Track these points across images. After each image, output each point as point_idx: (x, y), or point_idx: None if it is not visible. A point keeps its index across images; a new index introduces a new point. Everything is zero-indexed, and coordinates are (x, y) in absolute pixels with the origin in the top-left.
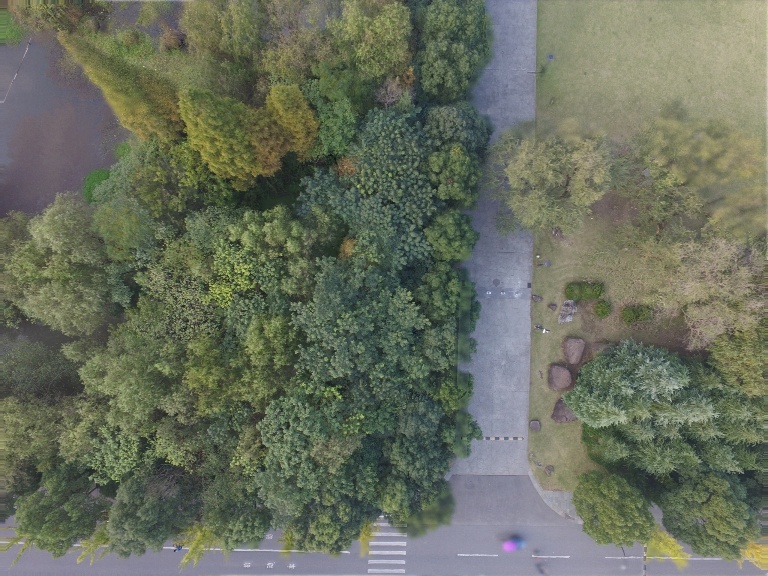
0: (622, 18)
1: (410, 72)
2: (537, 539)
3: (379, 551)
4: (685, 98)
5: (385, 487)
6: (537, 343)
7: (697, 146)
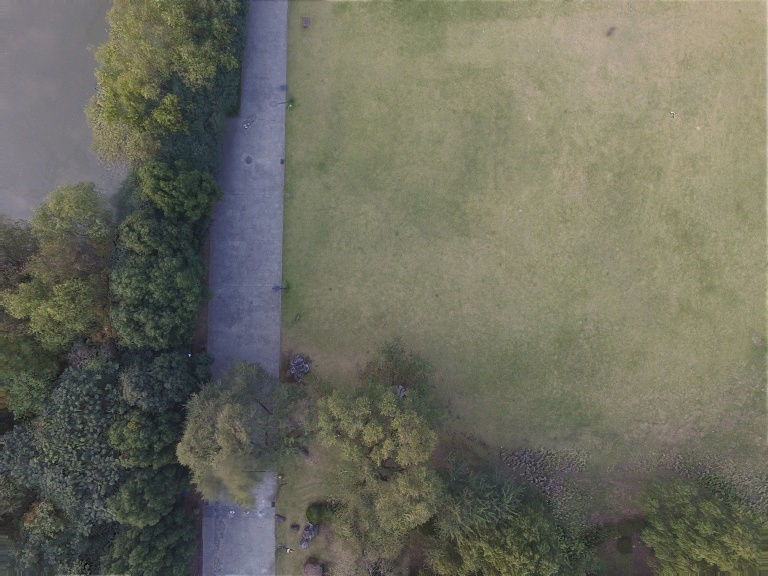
0: (368, 233)
1: (105, 331)
2: None
3: None
4: (433, 313)
5: None
6: (282, 562)
7: (445, 361)
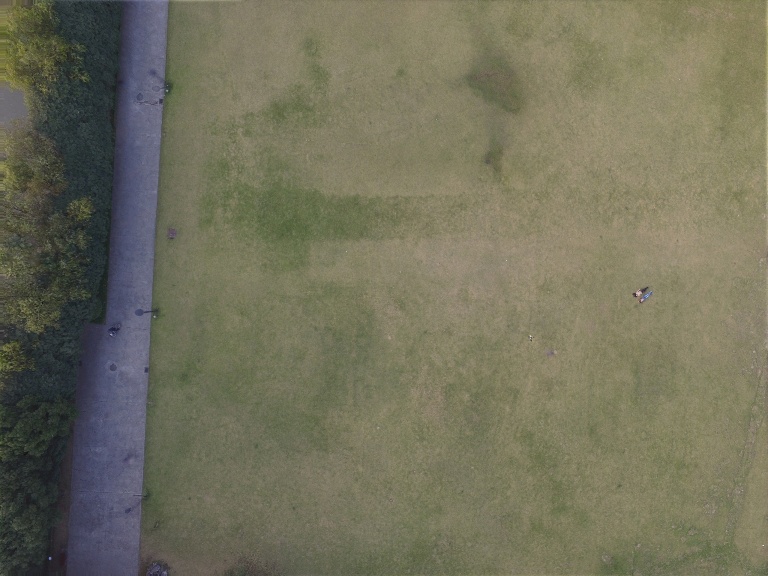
0: (227, 445)
1: None
2: None
3: None
4: (289, 525)
5: None
6: None
7: (300, 572)
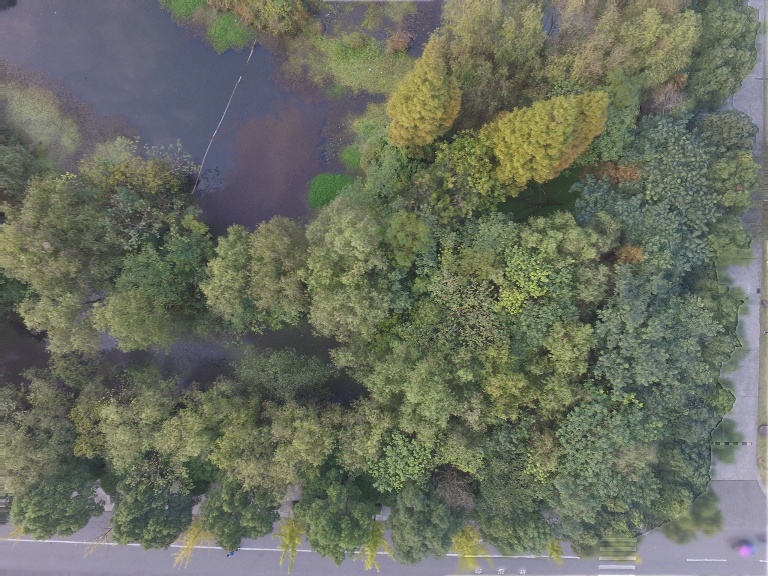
0: None
1: (684, 78)
2: (765, 544)
3: (609, 556)
4: None
5: (672, 493)
6: (766, 348)
7: None
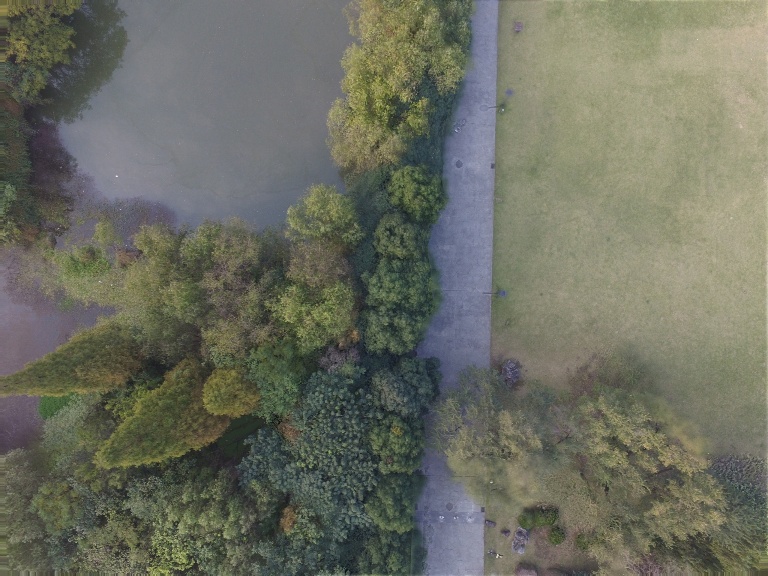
0: (579, 238)
1: (354, 335)
2: None
3: None
4: (643, 319)
5: None
6: (490, 567)
7: (655, 368)
